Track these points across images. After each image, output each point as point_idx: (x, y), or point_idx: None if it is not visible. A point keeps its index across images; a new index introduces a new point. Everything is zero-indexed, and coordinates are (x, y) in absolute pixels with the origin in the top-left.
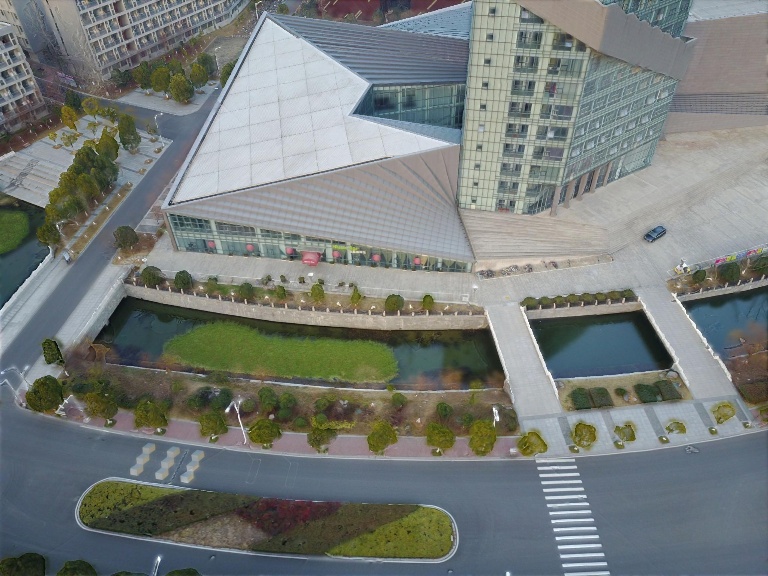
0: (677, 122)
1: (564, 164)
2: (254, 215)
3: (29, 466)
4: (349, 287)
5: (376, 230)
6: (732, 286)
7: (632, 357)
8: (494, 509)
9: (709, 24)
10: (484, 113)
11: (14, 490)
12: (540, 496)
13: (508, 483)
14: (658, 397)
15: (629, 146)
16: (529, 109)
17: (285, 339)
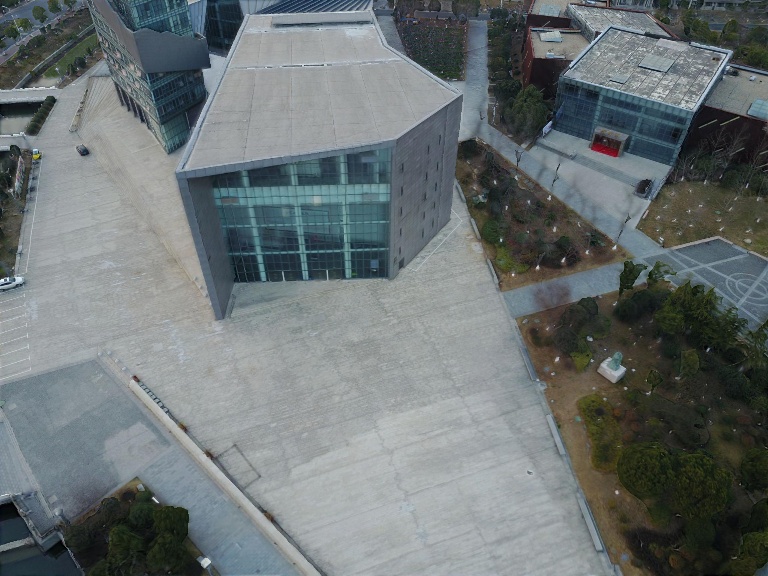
0: None
1: None
2: None
3: None
4: None
5: None
6: None
7: None
8: None
9: None
10: None
11: None
12: None
13: None
14: None
15: None
16: None
17: None
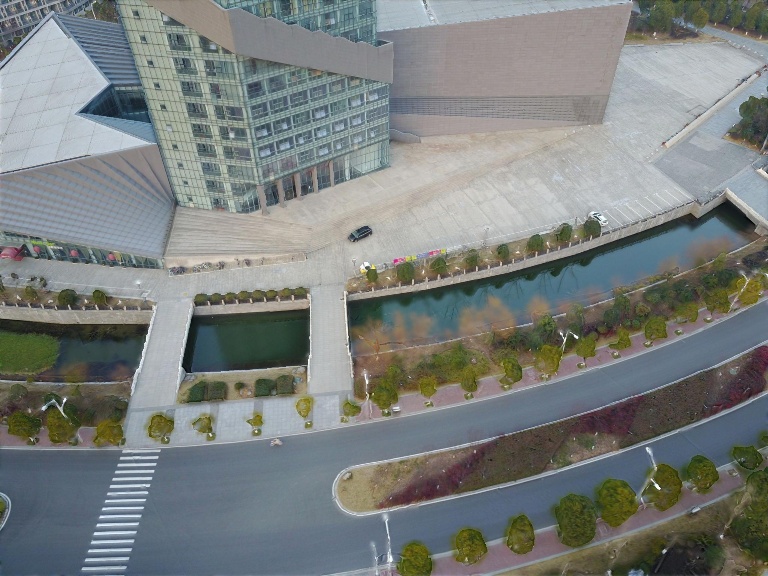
0: (432, 125)
1: (255, 164)
2: None
3: None
4: (40, 282)
5: (73, 226)
6: (407, 285)
7: (286, 353)
8: (55, 496)
9: (444, 29)
10: (167, 113)
11: None
12: (106, 485)
13: (83, 472)
14: (273, 391)
15: (347, 147)
16: (205, 110)
17: None
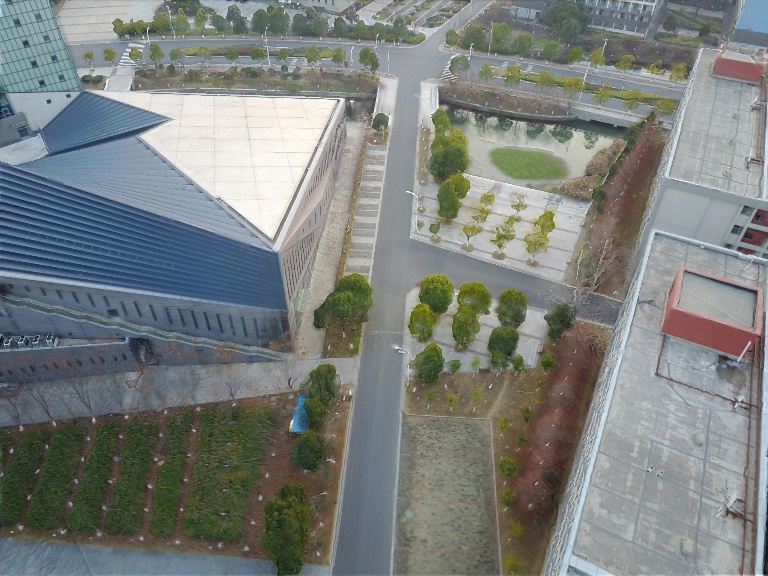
0: None
1: None
2: None
3: None
4: None
5: None
6: None
7: None
8: None
9: None
10: None
11: None
12: None
13: None
14: None
15: None
16: None
17: None
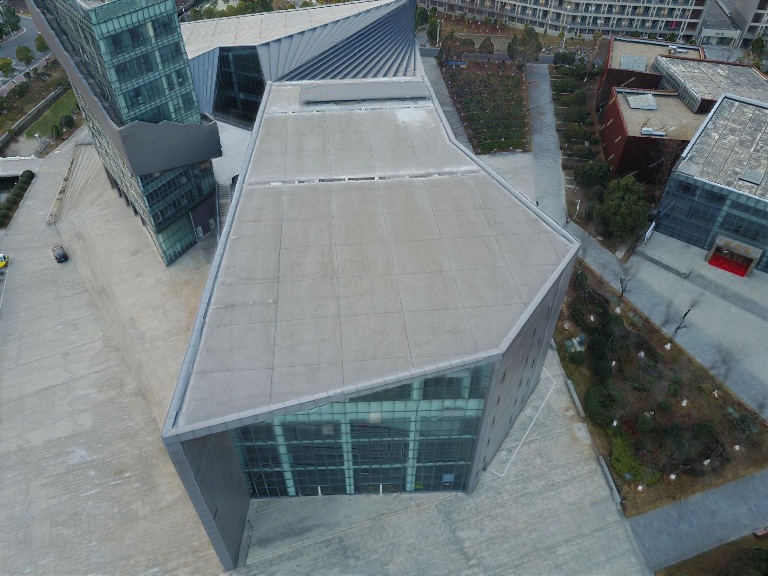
0: None
1: None
2: None
3: None
4: None
5: None
6: None
7: None
8: None
9: None
10: None
11: (26, 46)
12: None
13: None
14: None
15: None
16: None
17: None
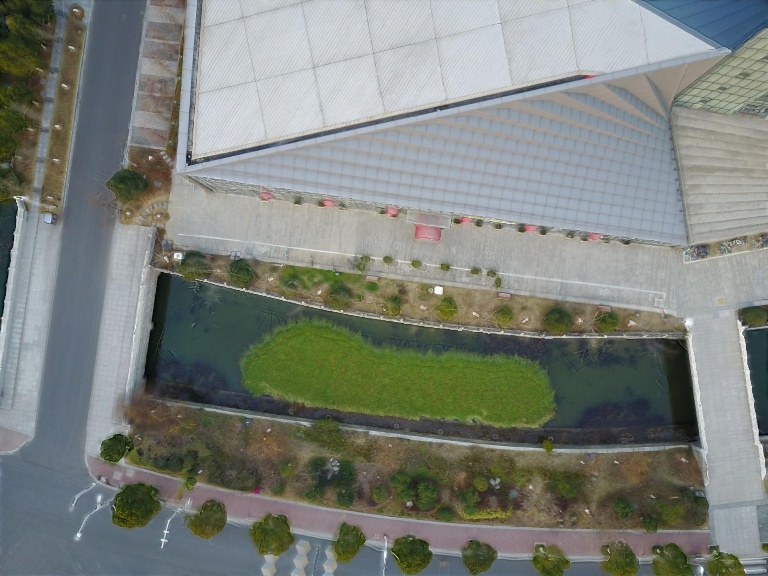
0: None
1: None
2: (336, 177)
3: (147, 565)
4: (487, 275)
5: (537, 194)
6: None
7: None
8: None
9: None
10: None
11: None
12: None
13: None
14: None
15: None
16: None
17: (401, 353)
